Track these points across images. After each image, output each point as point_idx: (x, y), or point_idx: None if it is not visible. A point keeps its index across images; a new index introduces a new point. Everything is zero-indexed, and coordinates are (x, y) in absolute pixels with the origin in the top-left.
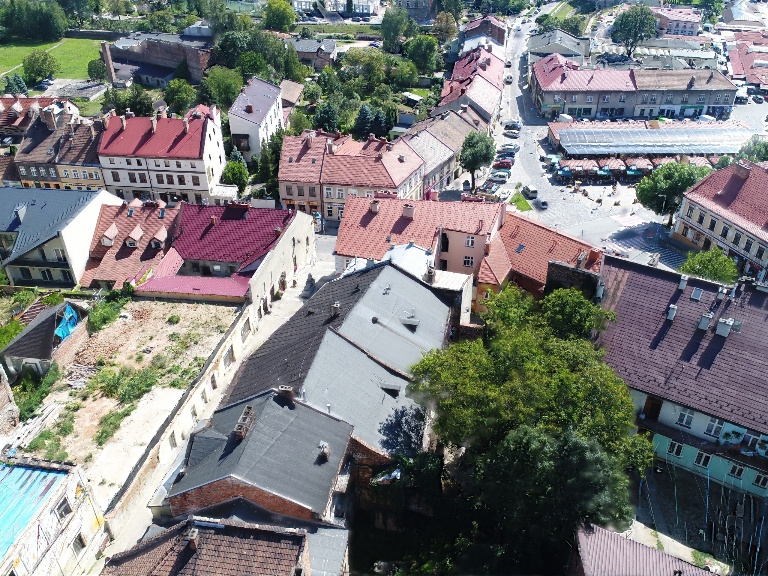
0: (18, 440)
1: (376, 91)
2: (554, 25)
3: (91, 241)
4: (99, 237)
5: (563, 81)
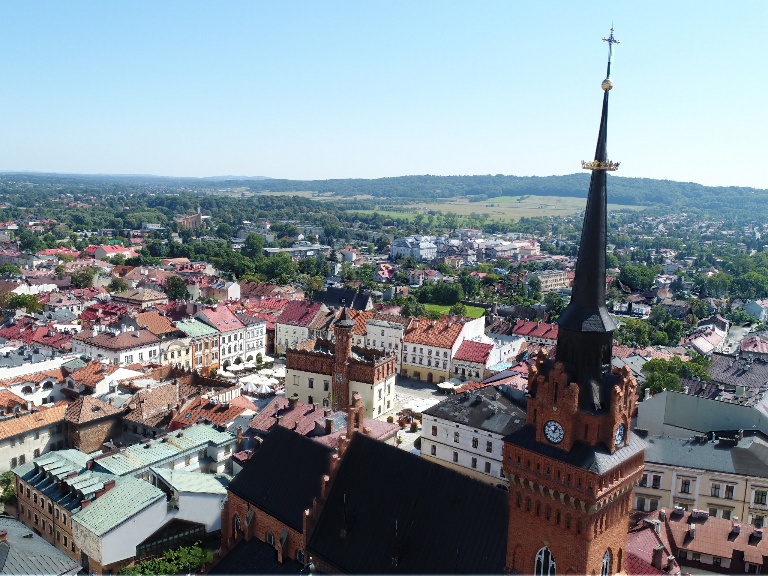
0: None
1: (641, 342)
2: (765, 328)
3: (518, 353)
4: (522, 351)
5: (755, 347)
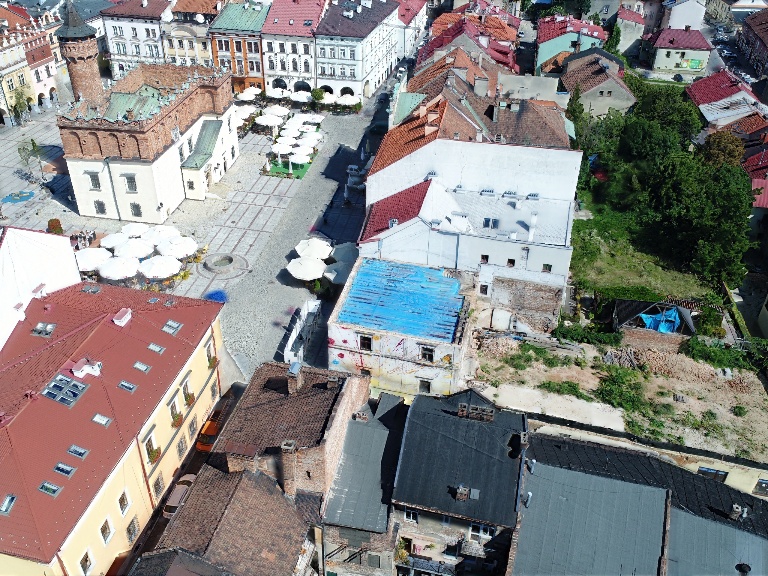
0: (533, 338)
1: None
2: None
3: None
4: None
5: None
